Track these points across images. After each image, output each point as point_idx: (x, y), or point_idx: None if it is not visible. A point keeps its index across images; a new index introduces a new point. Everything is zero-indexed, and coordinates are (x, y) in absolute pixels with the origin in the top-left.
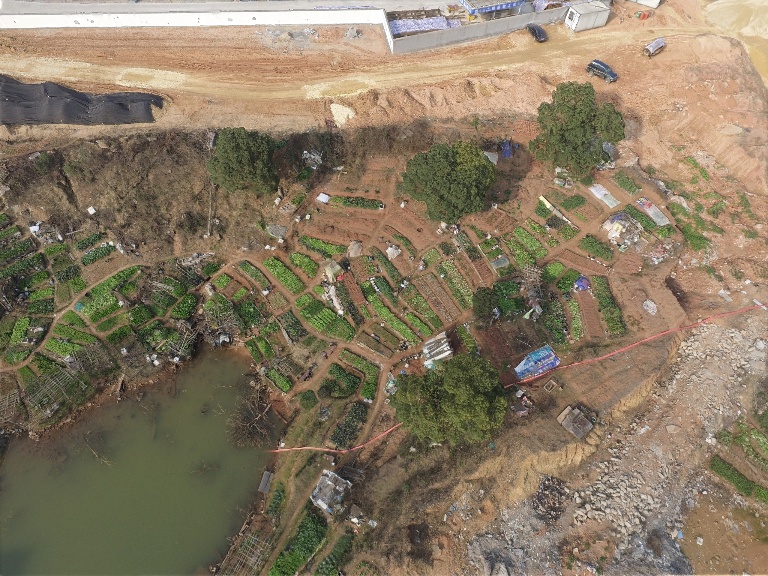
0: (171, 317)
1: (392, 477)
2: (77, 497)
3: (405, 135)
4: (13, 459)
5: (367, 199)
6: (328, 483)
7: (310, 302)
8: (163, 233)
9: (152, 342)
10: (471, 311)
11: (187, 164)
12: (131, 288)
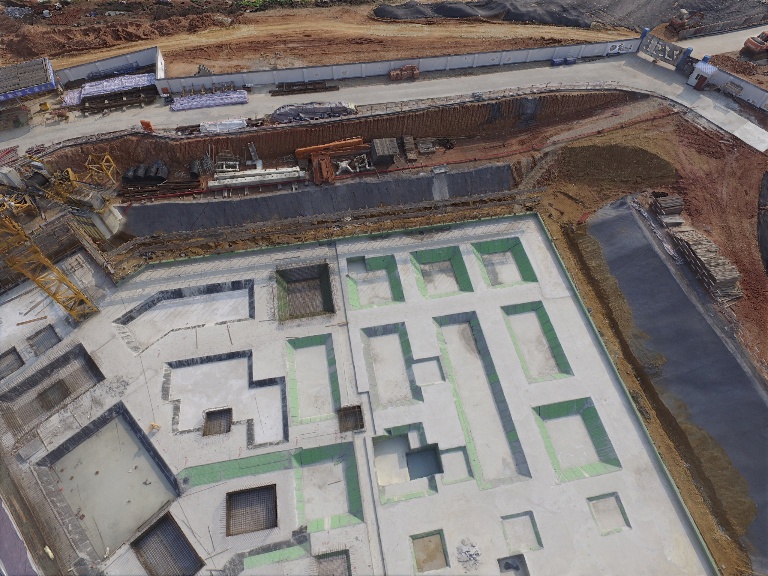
0: None
1: None
2: None
3: None
4: None
5: None
6: None
7: None
8: None
9: None
10: None
11: None
12: None
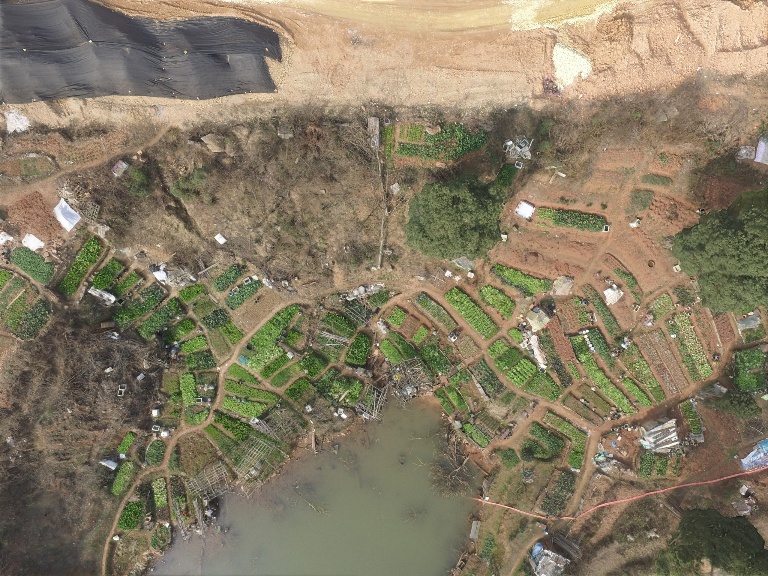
0: (346, 362)
1: (610, 560)
2: (307, 540)
3: (666, 117)
4: (235, 508)
5: (587, 215)
6: (550, 562)
7: (506, 350)
8: (320, 266)
9: (334, 395)
10: (701, 383)
11: (345, 178)
12: (296, 336)
